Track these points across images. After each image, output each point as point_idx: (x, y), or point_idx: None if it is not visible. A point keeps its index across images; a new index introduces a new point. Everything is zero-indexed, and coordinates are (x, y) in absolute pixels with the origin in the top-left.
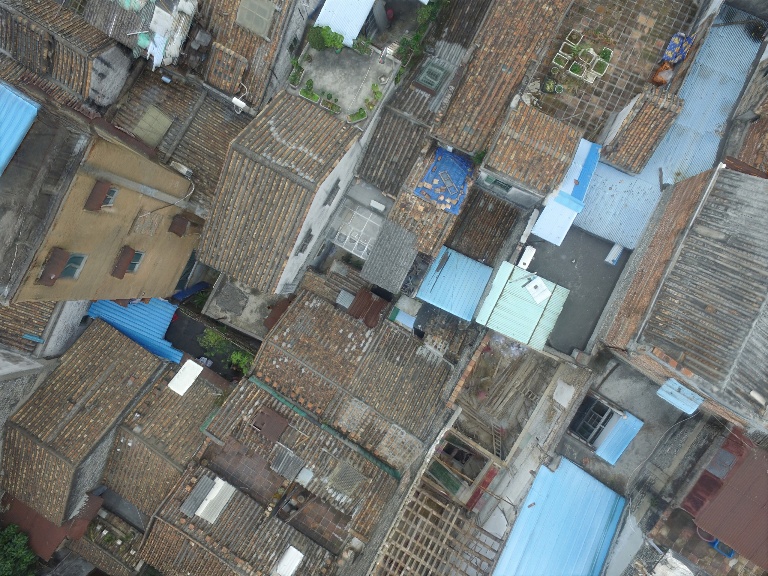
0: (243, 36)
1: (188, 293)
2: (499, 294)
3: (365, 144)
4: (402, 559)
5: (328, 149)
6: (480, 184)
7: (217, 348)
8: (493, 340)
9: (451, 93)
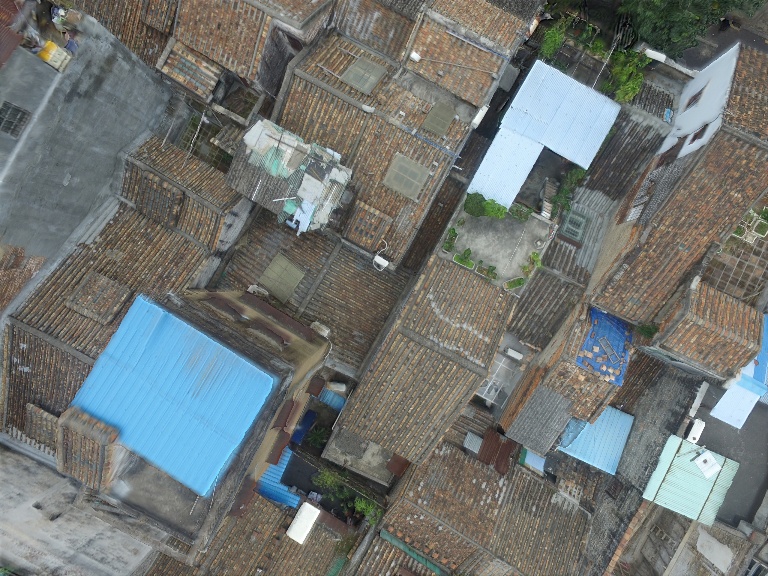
0: (387, 194)
1: (302, 432)
2: (667, 469)
3: None
4: None
5: (491, 324)
6: None
7: (336, 492)
8: None
9: (624, 270)
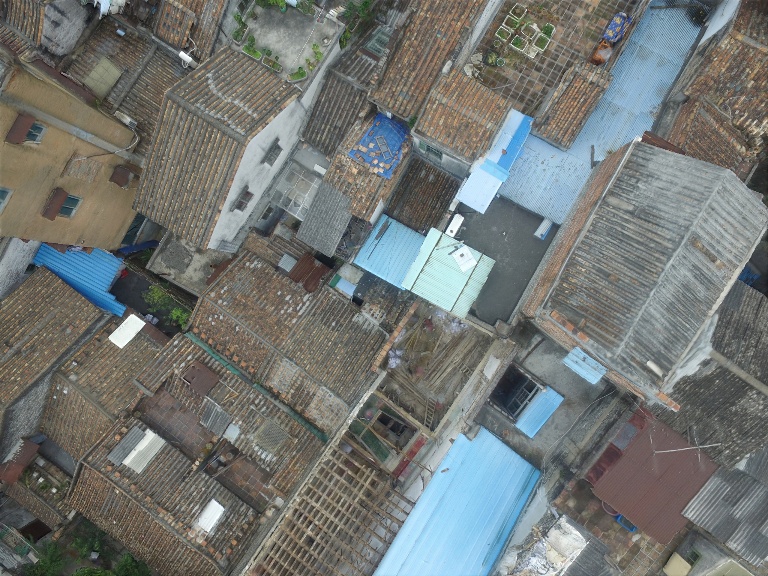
0: None
1: (135, 249)
2: (425, 260)
3: (309, 107)
4: (312, 513)
5: (264, 105)
6: (417, 152)
7: (160, 304)
8: (436, 315)
9: (386, 56)
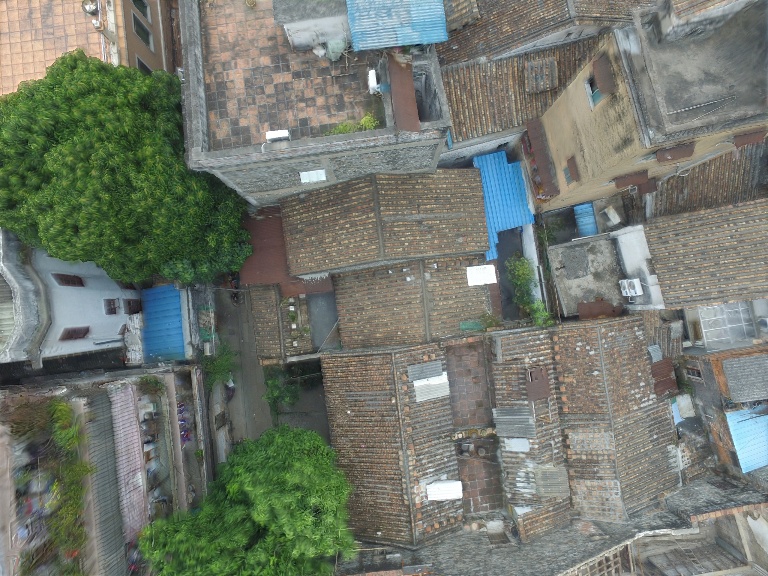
0: None
1: None
2: None
3: None
4: None
5: None
6: None
7: None
8: None
9: None
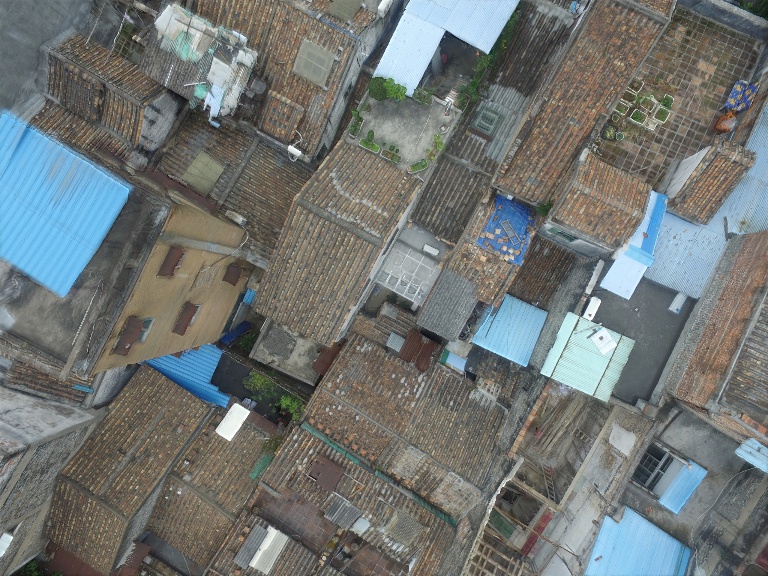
0: (299, 84)
1: (234, 336)
2: (564, 345)
3: (421, 190)
4: None
5: (391, 201)
6: (540, 232)
7: (264, 392)
8: None
9: (518, 146)
